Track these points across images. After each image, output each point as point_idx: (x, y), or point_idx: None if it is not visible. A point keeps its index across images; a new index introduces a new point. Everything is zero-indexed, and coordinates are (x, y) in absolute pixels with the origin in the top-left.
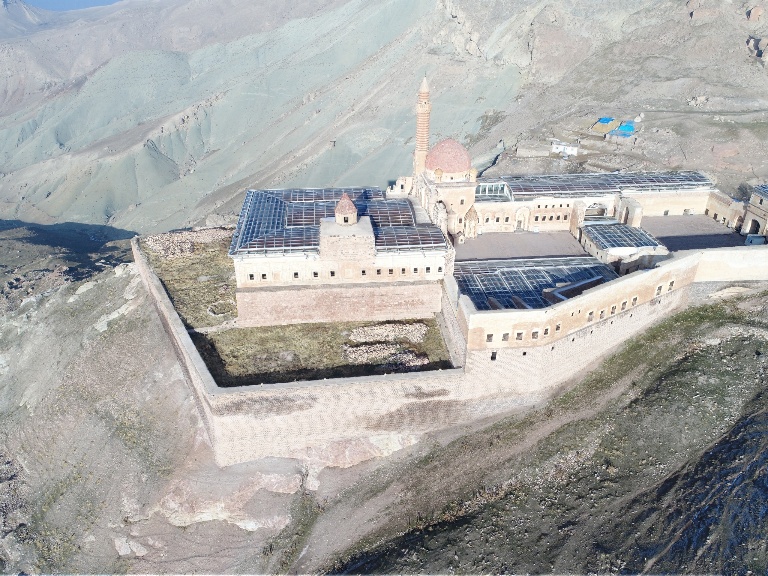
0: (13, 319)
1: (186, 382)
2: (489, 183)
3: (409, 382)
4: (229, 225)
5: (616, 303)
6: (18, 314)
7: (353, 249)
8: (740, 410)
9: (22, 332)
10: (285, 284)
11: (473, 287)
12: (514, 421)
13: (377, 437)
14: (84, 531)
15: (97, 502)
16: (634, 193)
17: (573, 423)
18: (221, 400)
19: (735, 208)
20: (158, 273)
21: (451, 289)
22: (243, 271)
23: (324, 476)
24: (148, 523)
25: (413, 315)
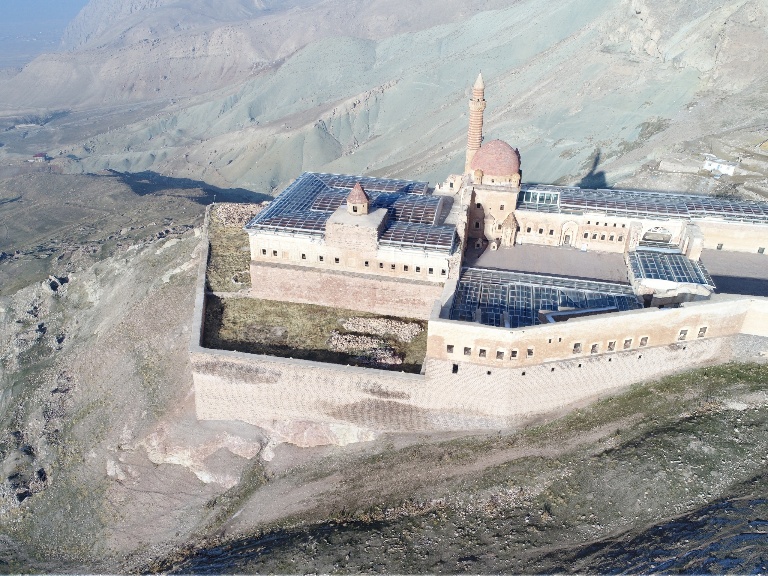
0: (117, 261)
1: None
2: (541, 191)
3: (368, 378)
4: None
5: (615, 339)
6: (122, 258)
7: (356, 239)
8: (723, 490)
9: (118, 273)
10: (293, 263)
11: (470, 296)
12: (473, 441)
13: (338, 425)
14: (91, 447)
15: (108, 426)
16: (719, 222)
17: (531, 458)
18: (197, 358)
19: None
20: (211, 238)
21: (445, 294)
22: (257, 245)
23: (280, 450)
24: (133, 453)
25: (414, 314)
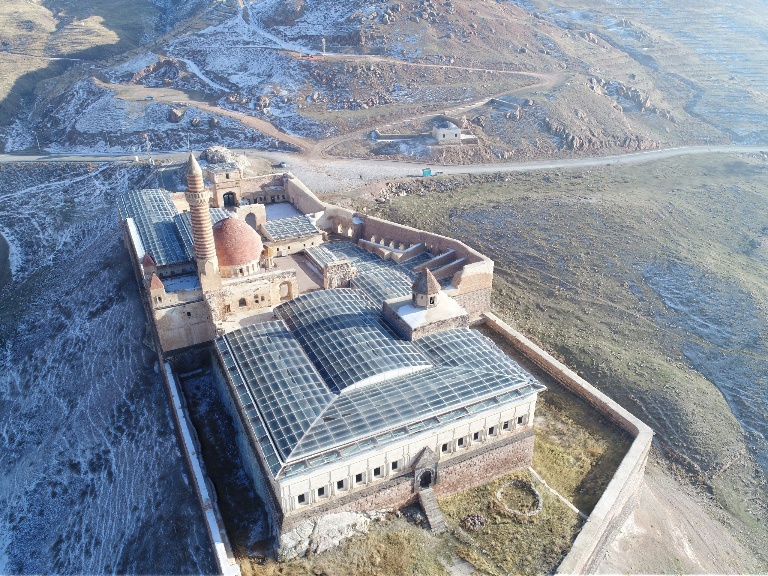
0: None
1: (596, 572)
2: None
3: None
4: None
5: None
6: None
7: None
8: None
9: None
10: None
11: None
12: None
13: None
14: None
15: None
16: None
17: None
18: None
19: None
20: None
21: None
22: None
23: None
24: (714, 575)
25: None
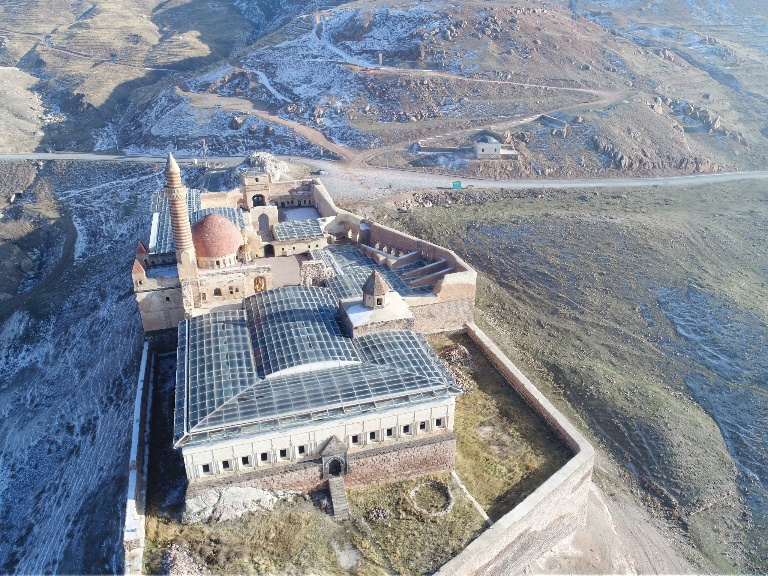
0: None
1: None
2: None
3: None
4: (138, 568)
5: None
6: None
7: None
8: None
9: None
10: None
11: None
12: None
13: None
14: None
15: None
16: None
17: None
18: None
19: (233, 196)
20: None
21: None
22: None
23: None
24: None
25: None
